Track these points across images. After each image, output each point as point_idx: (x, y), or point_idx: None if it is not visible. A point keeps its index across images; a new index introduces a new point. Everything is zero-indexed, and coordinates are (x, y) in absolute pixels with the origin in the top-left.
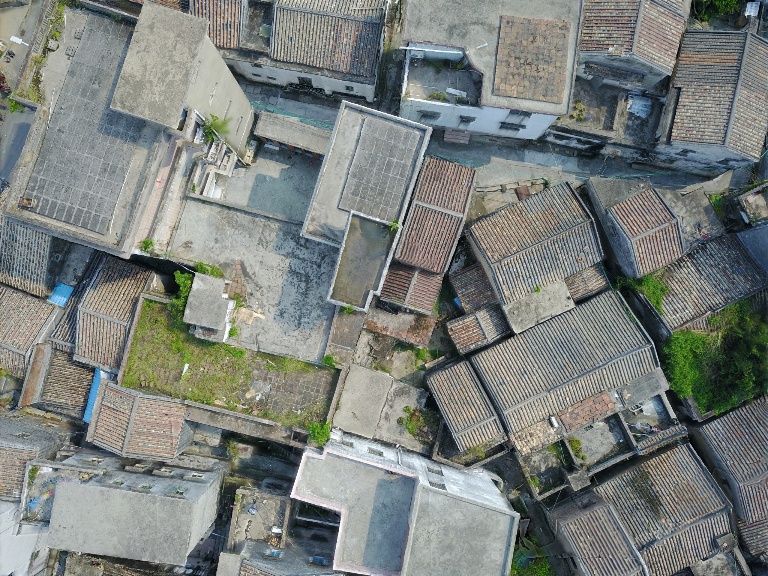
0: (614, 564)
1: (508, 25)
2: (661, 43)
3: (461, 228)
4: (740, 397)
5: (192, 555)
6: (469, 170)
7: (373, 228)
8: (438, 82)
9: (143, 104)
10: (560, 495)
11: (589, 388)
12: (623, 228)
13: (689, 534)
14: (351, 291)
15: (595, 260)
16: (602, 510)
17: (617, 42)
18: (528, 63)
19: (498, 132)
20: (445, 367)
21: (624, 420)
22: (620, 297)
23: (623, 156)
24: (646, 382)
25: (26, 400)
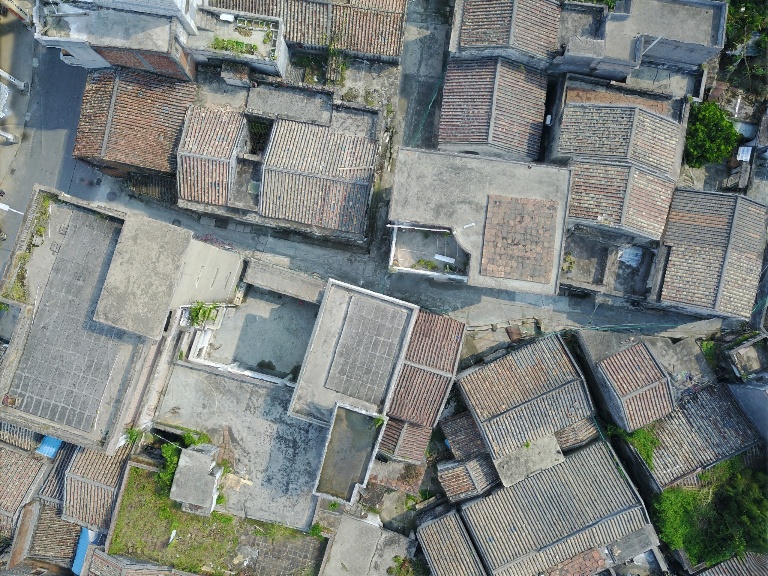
0: None
1: (495, 205)
2: (650, 210)
3: (450, 387)
4: None
5: None
6: (458, 324)
7: (359, 419)
8: (426, 246)
9: (126, 316)
10: None
11: (579, 546)
12: (613, 386)
13: None
14: (337, 483)
15: (585, 414)
16: None
17: (606, 211)
18: (515, 243)
19: None
20: (435, 512)
21: (615, 572)
22: (610, 450)
23: (614, 305)
24: (636, 538)
25: (14, 561)
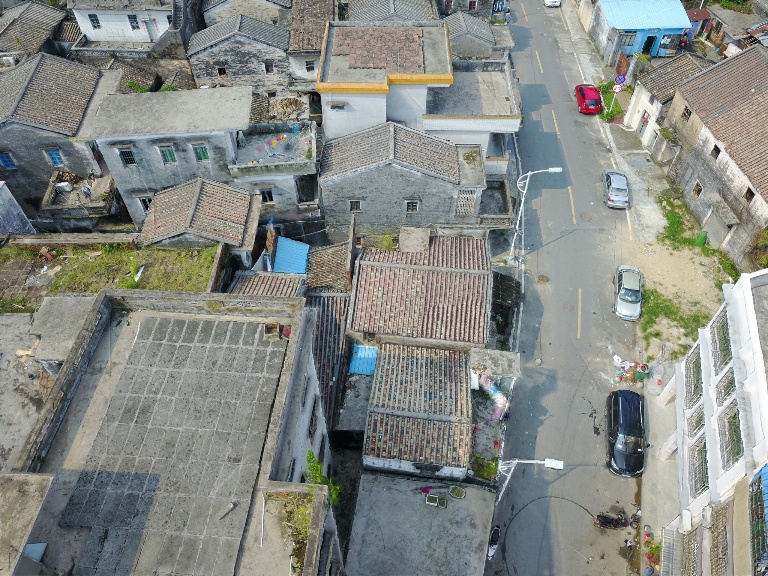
0: None
1: None
2: None
3: None
4: None
5: None
6: None
7: None
8: None
9: None
10: None
11: None
12: None
13: None
14: None
15: None
16: None
17: None
18: None
19: None
20: None
21: None
22: None
23: None
24: None
25: None
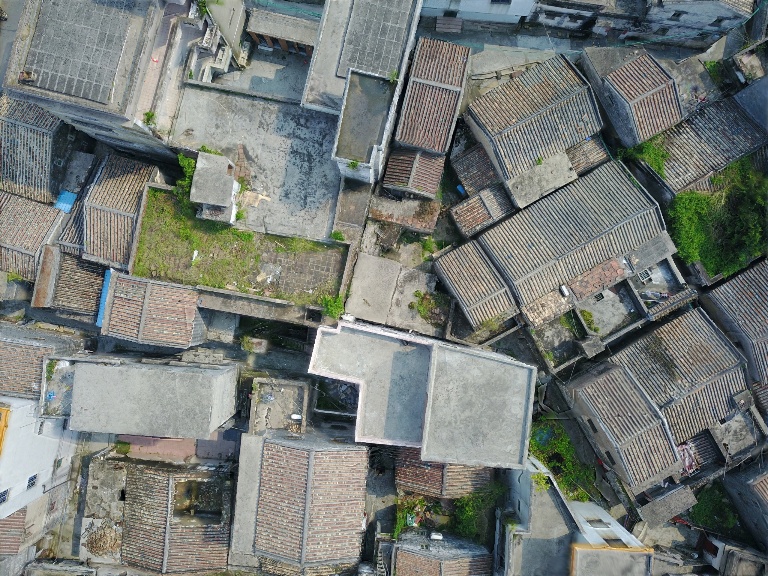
0: (633, 421)
1: None
2: None
3: (459, 103)
4: (747, 257)
5: (213, 457)
6: (463, 48)
7: (373, 84)
8: None
9: None
10: (575, 367)
11: (597, 255)
12: (620, 93)
13: (706, 393)
14: (355, 148)
15: (595, 129)
16: (618, 372)
17: None
18: None
19: (490, 9)
20: None
21: (634, 289)
22: (622, 165)
23: (616, 27)
24: (653, 246)
25: (38, 301)
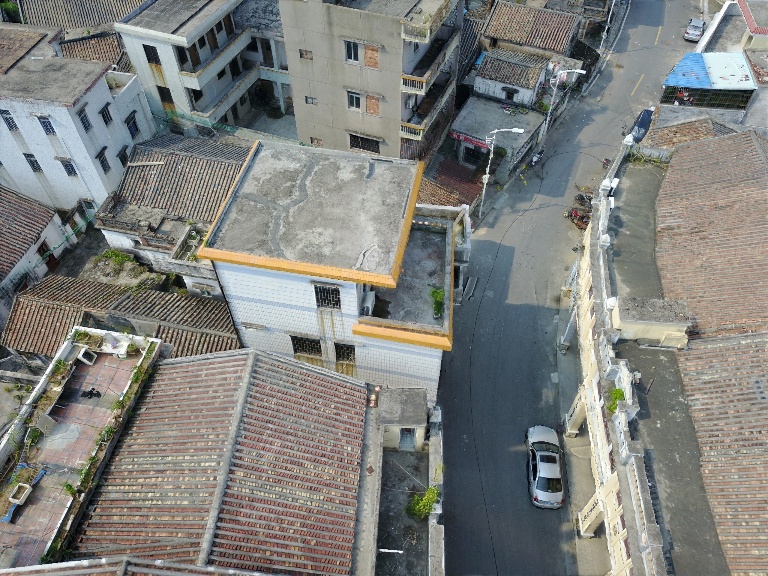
0: None
1: (3, 66)
2: None
3: None
4: None
5: None
6: None
7: None
8: None
9: None
10: None
11: None
12: None
13: None
14: None
15: None
16: None
17: None
18: (2, 45)
19: None
20: None
21: None
22: None
23: None
24: None
25: None
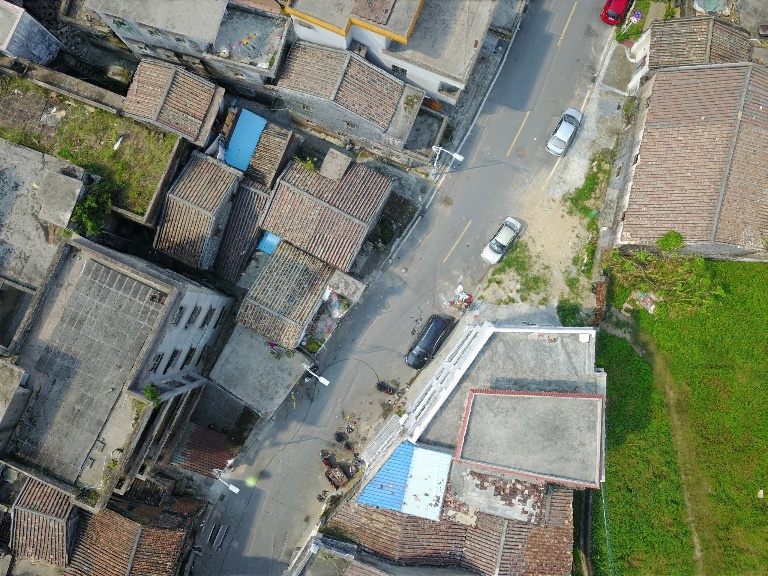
0: None
1: None
2: None
3: None
4: None
5: None
6: None
7: None
8: None
9: None
10: None
11: None
12: None
13: None
14: None
15: None
16: None
17: None
18: None
19: None
20: None
21: None
22: None
23: None
24: None
25: None
